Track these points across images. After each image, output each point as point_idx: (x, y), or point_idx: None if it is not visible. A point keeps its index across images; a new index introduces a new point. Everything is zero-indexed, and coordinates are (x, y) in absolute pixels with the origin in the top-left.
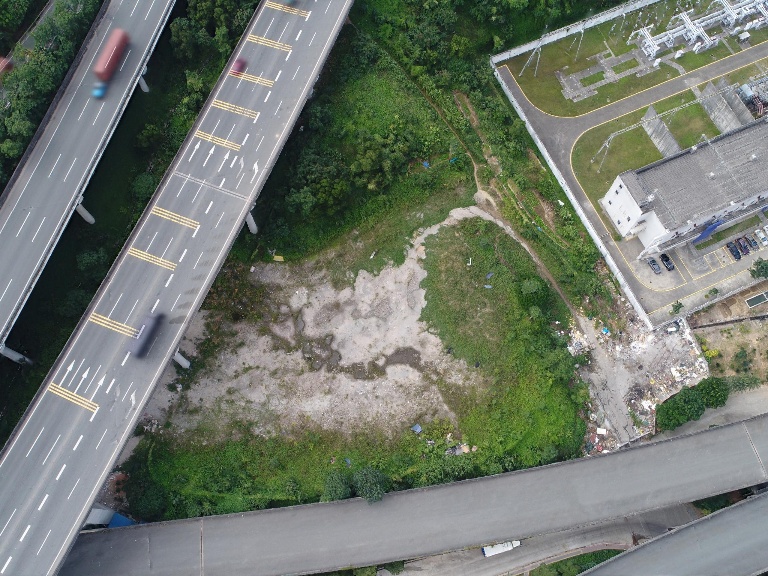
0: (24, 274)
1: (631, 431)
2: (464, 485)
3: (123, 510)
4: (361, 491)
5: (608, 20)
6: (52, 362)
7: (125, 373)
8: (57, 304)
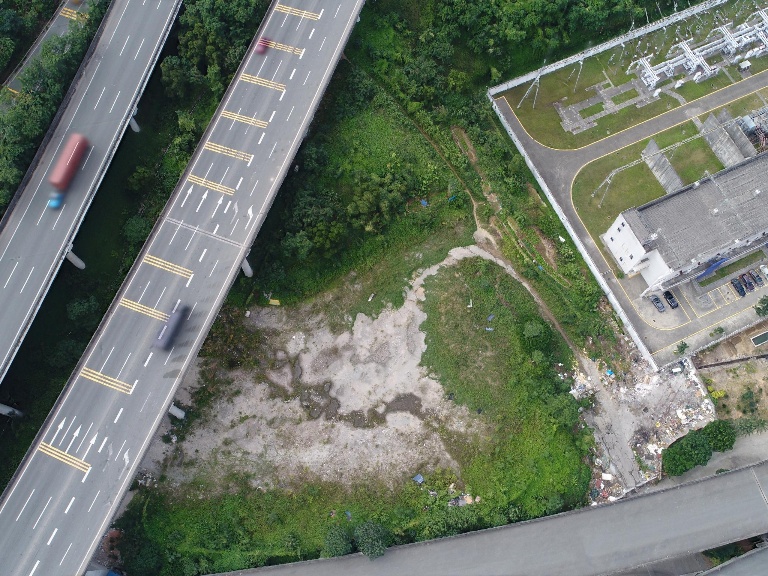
0: (12, 327)
1: (637, 476)
2: (468, 538)
3: (117, 568)
4: (362, 547)
5: (607, 49)
6: (43, 415)
7: (118, 431)
8: (47, 353)
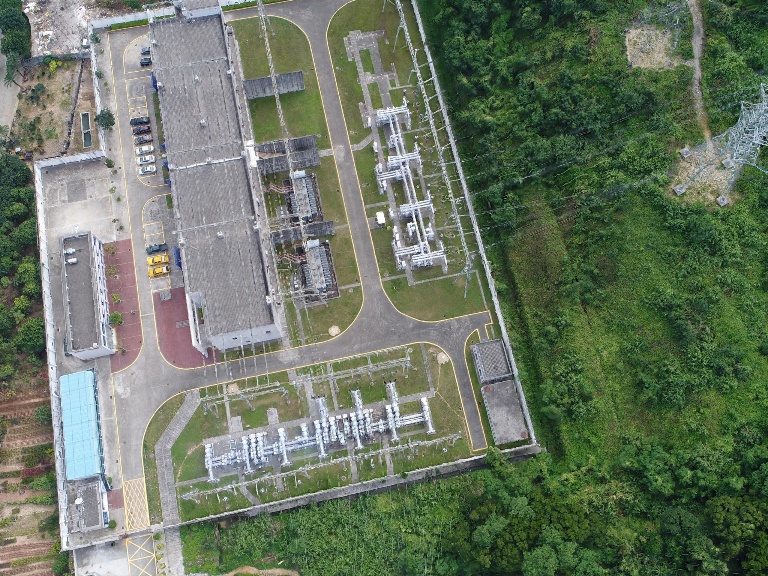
0: None
1: None
2: None
3: None
4: None
5: None
6: None
7: None
8: None
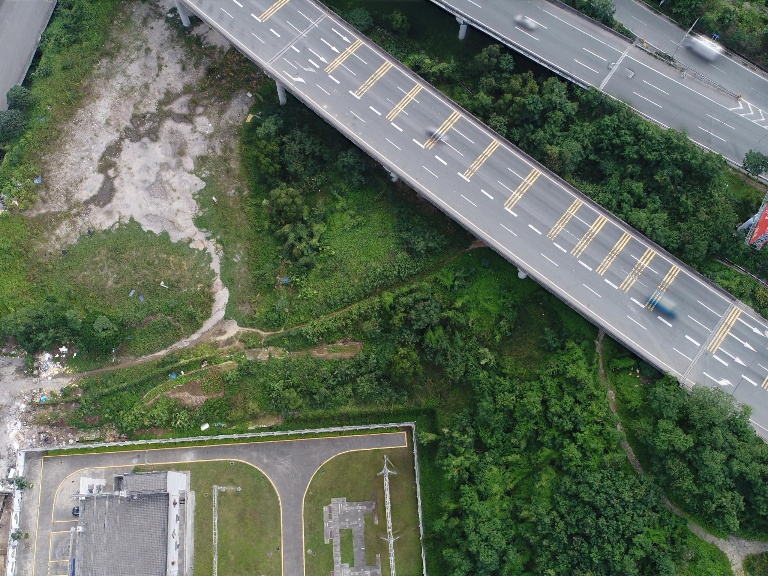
0: None
1: None
2: None
3: None
4: None
5: None
6: None
7: None
8: None
